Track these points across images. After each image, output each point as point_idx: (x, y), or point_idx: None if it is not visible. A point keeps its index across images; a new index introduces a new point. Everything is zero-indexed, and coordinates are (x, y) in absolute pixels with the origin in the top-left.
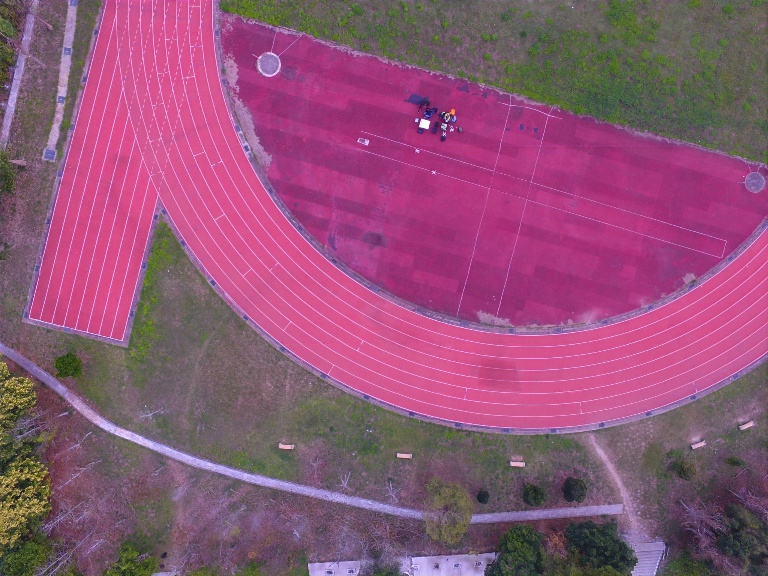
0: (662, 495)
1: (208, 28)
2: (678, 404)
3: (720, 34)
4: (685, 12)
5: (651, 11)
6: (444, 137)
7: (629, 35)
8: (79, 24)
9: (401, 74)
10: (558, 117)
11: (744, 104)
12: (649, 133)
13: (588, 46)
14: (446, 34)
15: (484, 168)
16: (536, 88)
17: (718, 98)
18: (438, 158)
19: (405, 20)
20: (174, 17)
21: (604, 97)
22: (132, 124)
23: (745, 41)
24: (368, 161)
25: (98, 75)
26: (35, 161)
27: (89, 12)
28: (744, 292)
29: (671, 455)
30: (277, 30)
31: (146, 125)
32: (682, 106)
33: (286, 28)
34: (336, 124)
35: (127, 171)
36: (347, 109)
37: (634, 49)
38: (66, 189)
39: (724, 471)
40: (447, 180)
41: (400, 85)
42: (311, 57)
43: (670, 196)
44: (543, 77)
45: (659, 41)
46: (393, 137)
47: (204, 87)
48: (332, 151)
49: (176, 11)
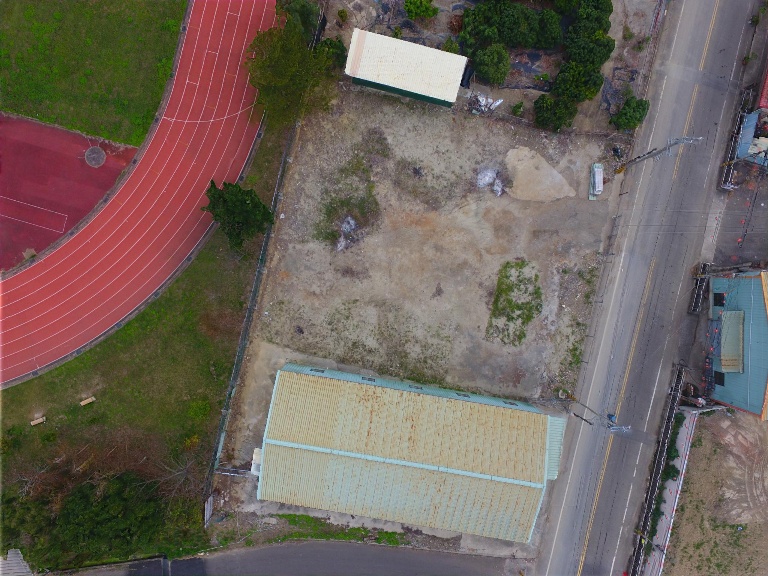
0: (4, 472)
1: None
2: (20, 380)
3: (55, 7)
4: None
5: None
6: None
7: None
8: None
9: None
10: None
11: (80, 78)
12: None
13: None
14: None
15: None
16: None
17: (54, 72)
18: None
19: None
20: None
21: None
22: None
23: (81, 14)
24: None
25: None
26: None
27: None
28: (86, 267)
29: (12, 432)
30: None
31: None
32: (17, 79)
33: None
34: None
35: None
36: None
37: None
38: None
39: (67, 447)
40: None
41: None
42: None
43: (8, 170)
44: None
45: None
46: None
47: None
48: None
49: None
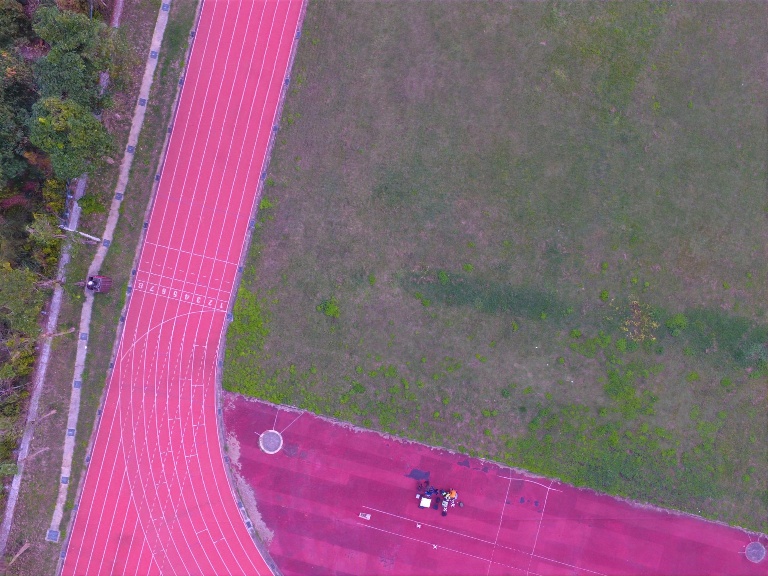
0: None
1: (211, 407)
2: None
3: (719, 406)
4: (684, 385)
5: (650, 384)
6: (445, 513)
7: (628, 409)
8: (83, 406)
9: (402, 449)
10: (558, 490)
11: (743, 476)
12: (649, 504)
13: (588, 420)
14: (446, 410)
15: (485, 541)
16: (536, 462)
17: (717, 470)
18: (439, 532)
19: (406, 397)
20: (177, 397)
21: (604, 471)
22: (135, 504)
23: (744, 413)
24: (370, 535)
25: (101, 456)
26: (38, 542)
27: (93, 394)
28: None
29: None
30: (279, 408)
31: (149, 504)
32: (682, 478)
33: (288, 406)
34: (338, 499)
35: (130, 550)
36: (348, 484)
37: (633, 422)
38: (69, 570)
39: None
40: (448, 553)
41: (401, 460)
42: (313, 434)
43: (671, 567)
44: (543, 451)
45: (658, 414)
46: (394, 512)
47: (206, 465)
48: (334, 526)
49: (179, 391)
